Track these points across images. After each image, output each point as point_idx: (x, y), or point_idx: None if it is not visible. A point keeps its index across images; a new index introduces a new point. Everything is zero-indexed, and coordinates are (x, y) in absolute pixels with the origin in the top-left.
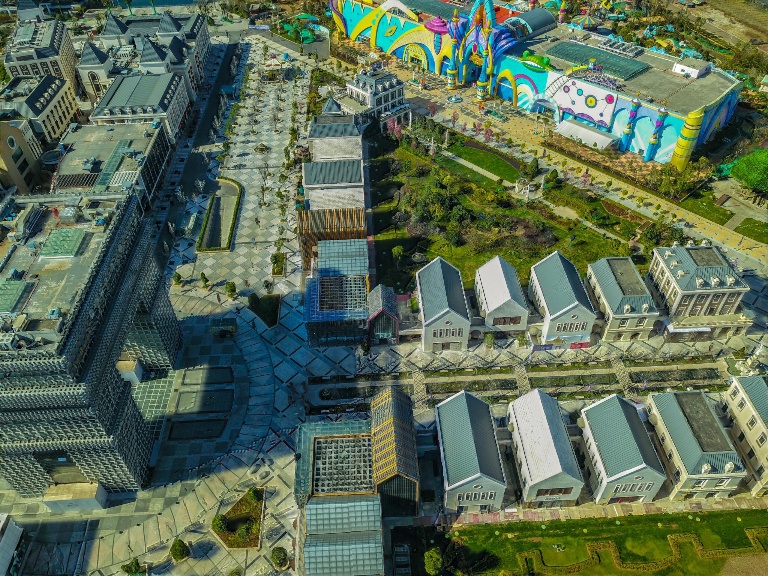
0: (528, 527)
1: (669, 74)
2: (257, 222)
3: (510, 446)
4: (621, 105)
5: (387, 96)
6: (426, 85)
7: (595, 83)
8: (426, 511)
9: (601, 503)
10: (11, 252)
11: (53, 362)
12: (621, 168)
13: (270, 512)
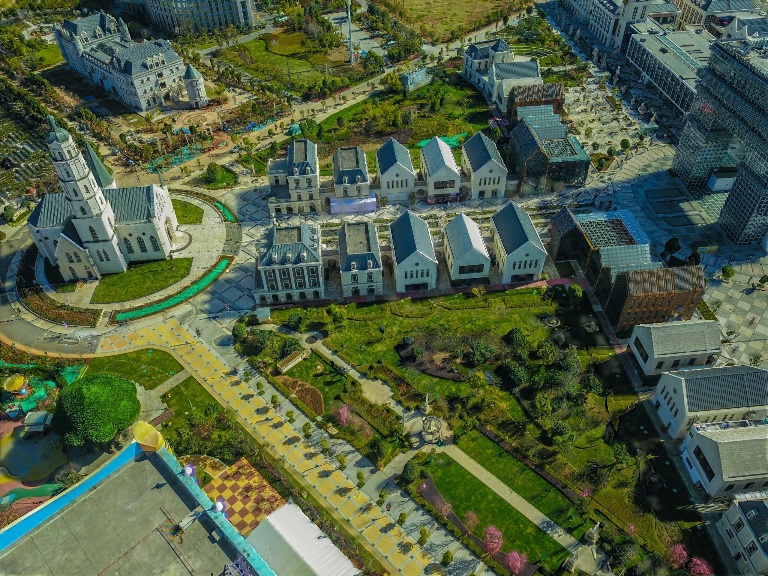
0: None
1: None
2: None
3: None
4: None
5: None
6: None
7: None
8: None
9: None
10: None
11: None
12: (264, 493)
13: None
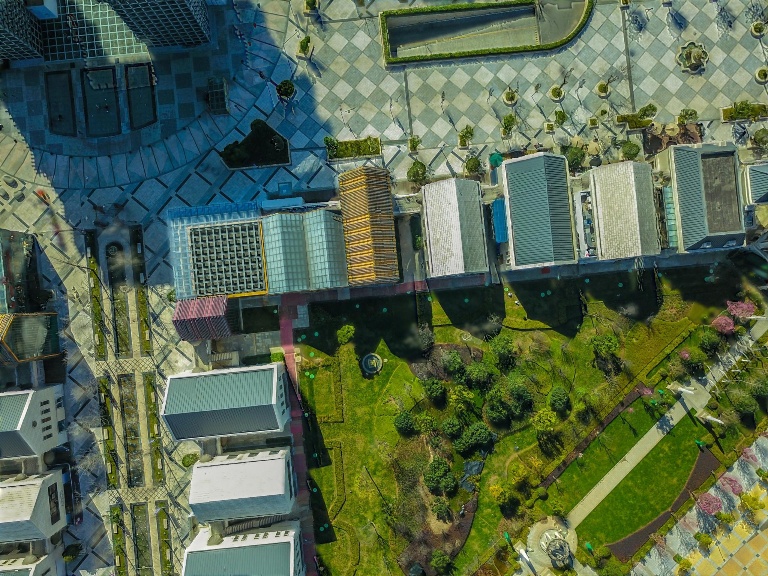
0: None
1: None
2: None
3: None
4: None
5: None
6: None
7: None
8: None
9: None
10: None
11: None
12: None
13: None
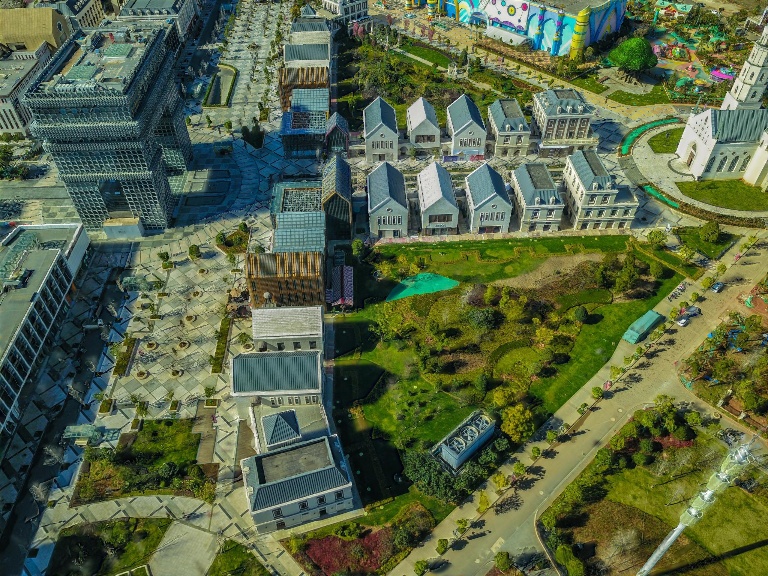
0: (424, 244)
1: None
2: (249, 88)
3: (417, 203)
4: (533, 11)
5: (353, 7)
6: (388, 6)
7: None
8: (358, 238)
9: (474, 232)
10: (84, 55)
11: (121, 98)
12: (532, 60)
13: (254, 239)
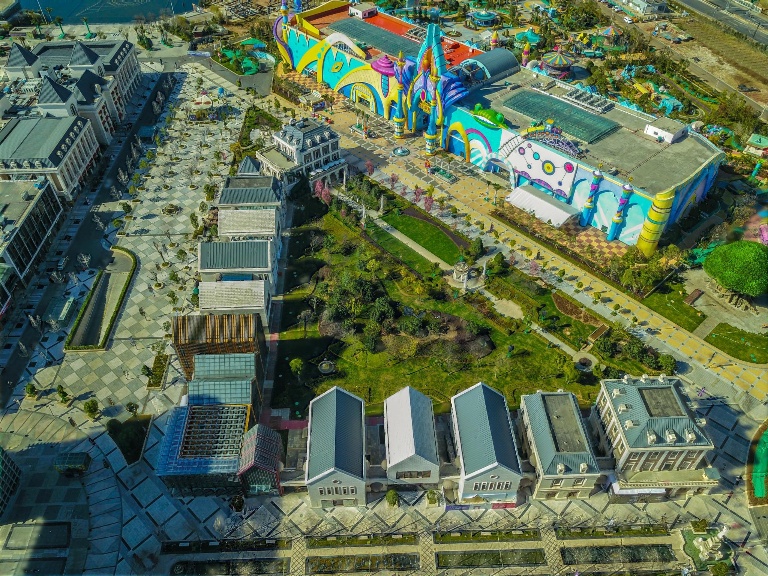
0: None
1: (640, 136)
2: (142, 313)
3: None
4: (581, 175)
5: (318, 151)
6: (371, 132)
7: (554, 147)
8: None
9: None
10: None
11: None
12: (579, 249)
13: None
